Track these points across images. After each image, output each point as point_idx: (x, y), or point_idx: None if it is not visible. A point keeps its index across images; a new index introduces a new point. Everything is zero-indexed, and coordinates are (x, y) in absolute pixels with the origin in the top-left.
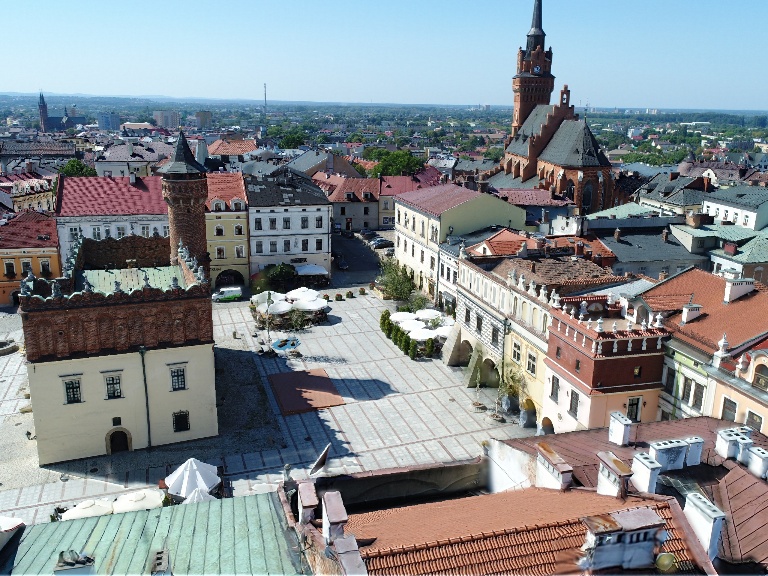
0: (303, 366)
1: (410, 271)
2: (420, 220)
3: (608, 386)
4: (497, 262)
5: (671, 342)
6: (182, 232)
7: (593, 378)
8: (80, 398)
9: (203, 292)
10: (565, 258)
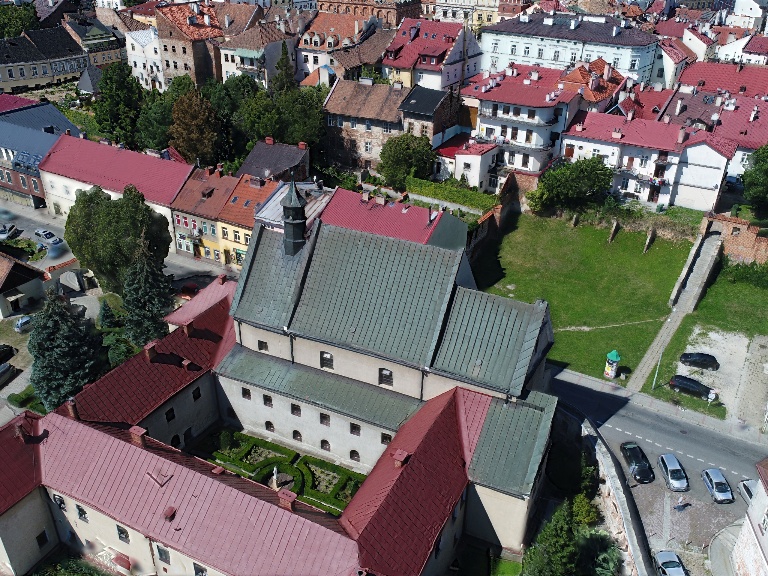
0: None
1: None
2: None
3: None
4: None
5: None
6: None
7: None
8: None
9: None
10: None
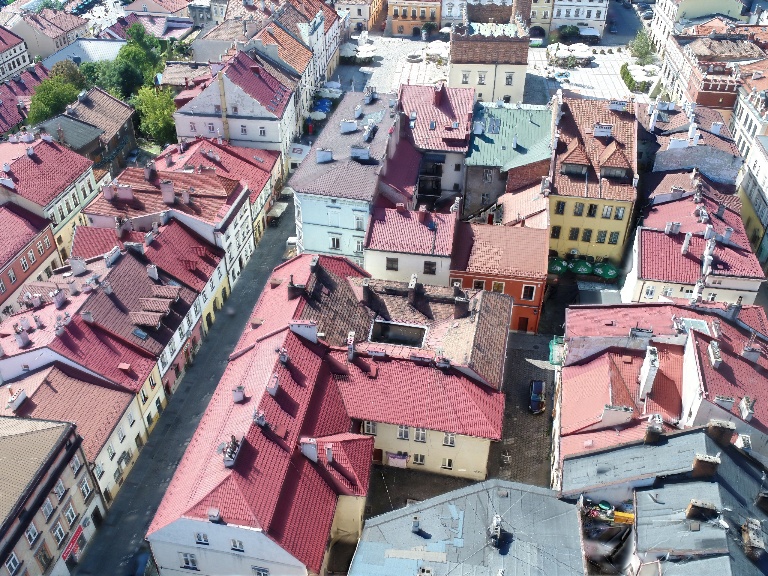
0: (569, 87)
1: (656, 39)
2: (669, 4)
3: (704, 105)
4: (694, 39)
5: (740, 88)
6: (520, 6)
7: (697, 100)
8: (468, 82)
9: (527, 40)
10: (740, 41)
